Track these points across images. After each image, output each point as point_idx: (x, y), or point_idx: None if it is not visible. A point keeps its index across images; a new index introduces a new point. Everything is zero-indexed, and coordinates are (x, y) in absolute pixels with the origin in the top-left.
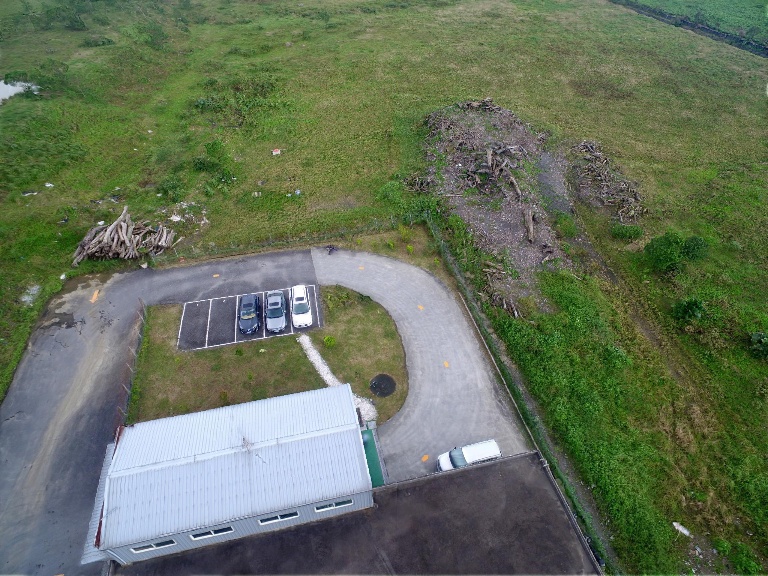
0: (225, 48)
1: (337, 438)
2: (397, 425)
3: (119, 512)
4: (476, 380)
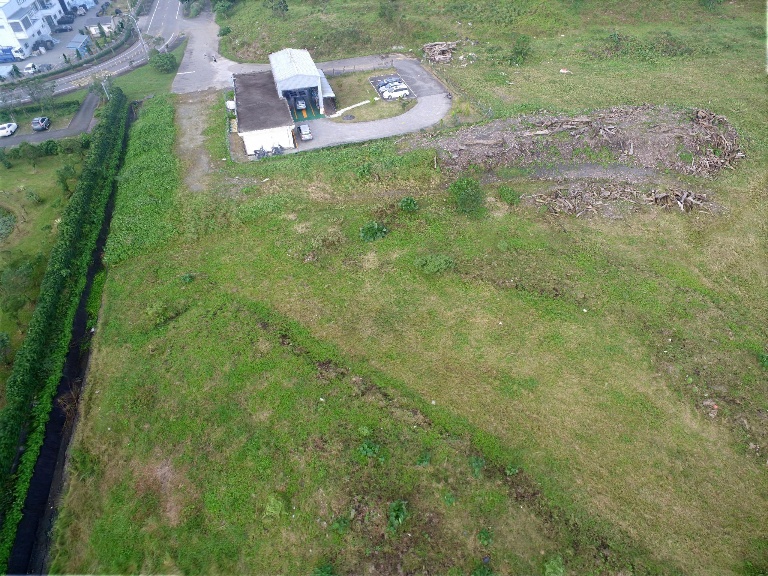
0: (765, 26)
1: (293, 72)
2: (327, 122)
3: (277, 53)
4: (351, 138)
